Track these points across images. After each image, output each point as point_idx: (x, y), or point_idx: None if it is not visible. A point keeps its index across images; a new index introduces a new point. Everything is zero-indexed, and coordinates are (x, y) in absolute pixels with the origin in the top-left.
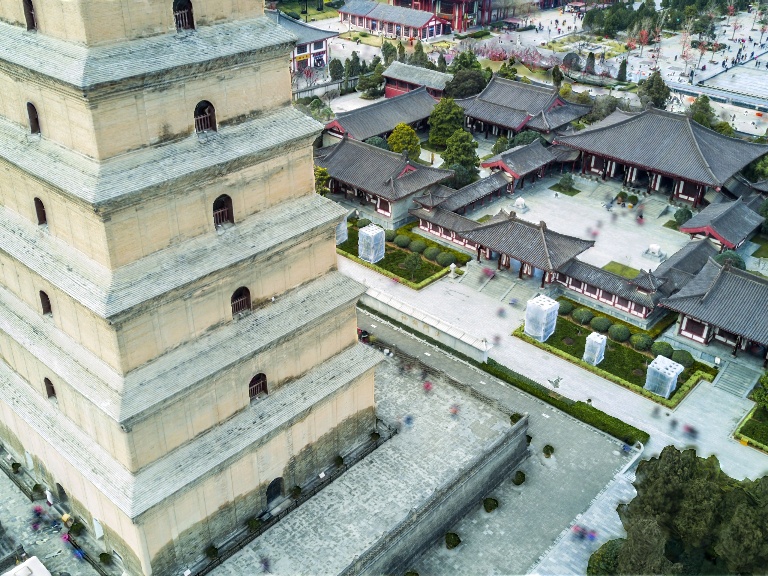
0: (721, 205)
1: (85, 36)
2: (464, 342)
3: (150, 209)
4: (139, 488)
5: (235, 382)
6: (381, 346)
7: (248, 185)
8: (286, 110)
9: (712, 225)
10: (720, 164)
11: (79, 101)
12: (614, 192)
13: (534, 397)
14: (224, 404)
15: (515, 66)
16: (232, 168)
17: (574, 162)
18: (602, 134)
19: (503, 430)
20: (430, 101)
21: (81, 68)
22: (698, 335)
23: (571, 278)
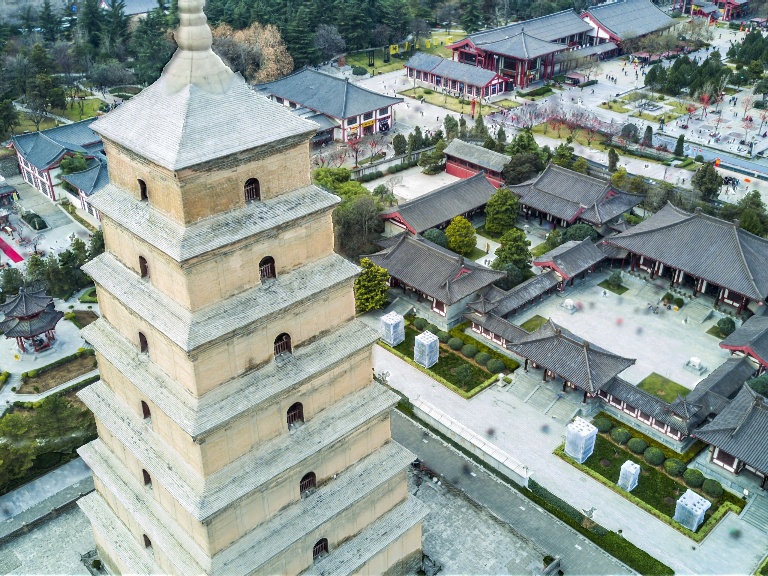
0: (763, 319)
1: (190, 305)
2: (507, 467)
3: (236, 427)
4: None
5: (301, 549)
6: (430, 473)
7: (316, 391)
8: (350, 324)
9: (751, 345)
10: (765, 274)
11: (183, 353)
12: (661, 293)
13: (569, 526)
14: (292, 567)
15: (572, 145)
16: (304, 382)
17: (623, 259)
18: (651, 236)
19: (536, 574)
20: (488, 186)
21: (186, 332)
22: (729, 465)
23: (612, 395)
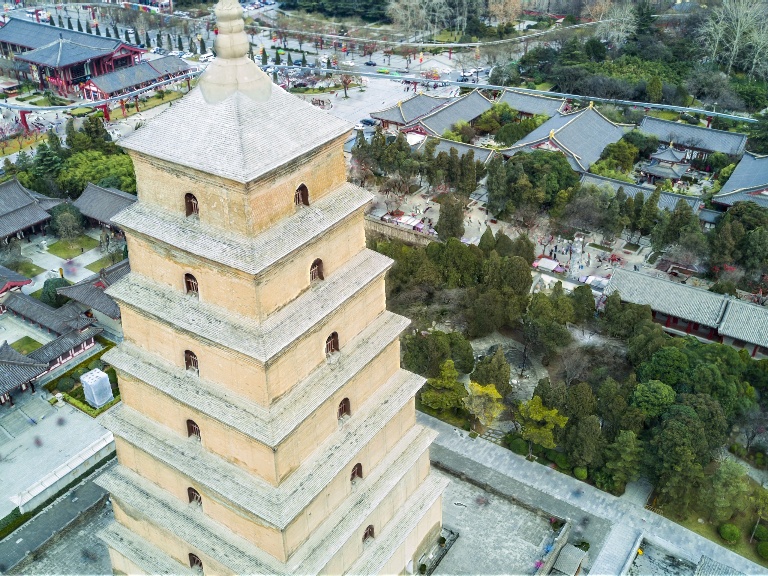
0: None
1: None
2: None
3: None
4: None
5: None
6: None
7: None
8: None
9: (8, 280)
10: None
11: None
12: None
13: None
14: None
15: None
16: None
17: None
18: None
19: None
20: None
21: (381, 257)
22: None
23: None
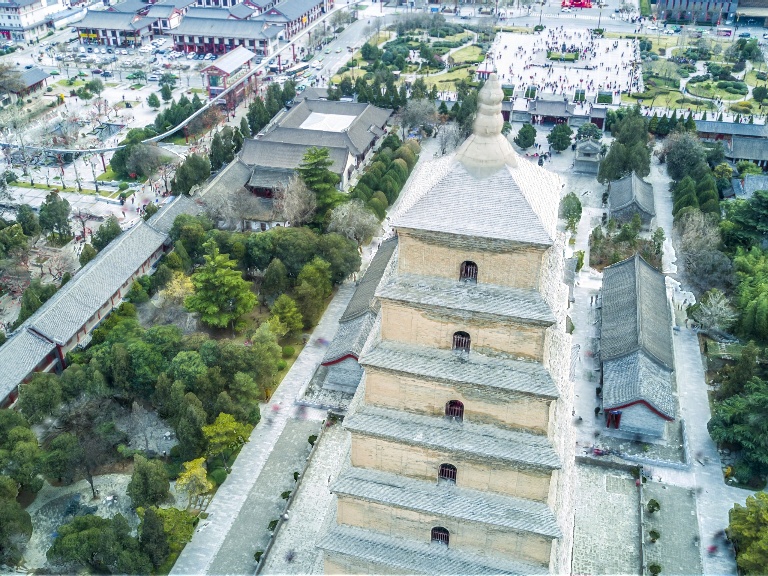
0: None
1: None
2: None
3: None
4: None
5: None
6: None
7: None
8: None
9: None
10: None
11: None
12: None
13: None
14: None
15: None
16: None
17: None
18: None
19: None
20: None
21: None
22: None
23: None
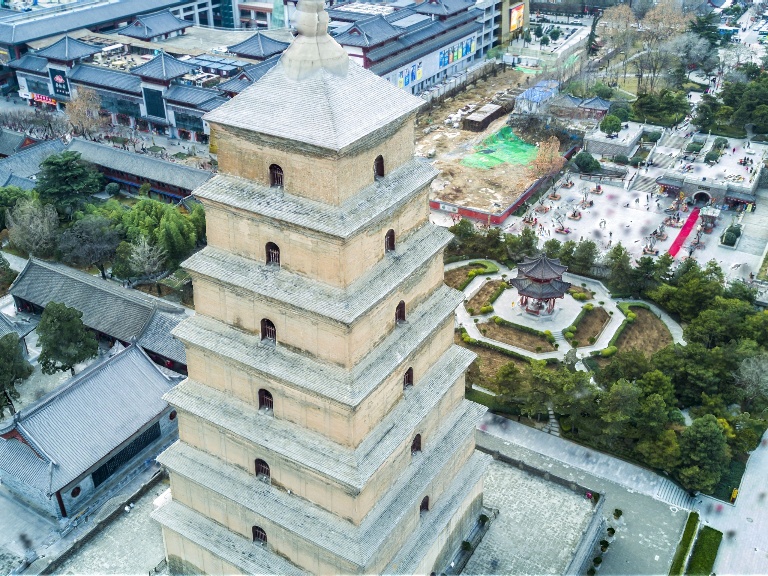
0: None
1: None
2: None
3: (214, 361)
4: (167, 507)
5: (241, 514)
6: None
7: None
8: (341, 369)
9: None
10: None
11: None
12: None
13: None
14: (233, 520)
15: None
16: None
17: None
18: None
19: None
20: None
21: None
22: None
23: None
